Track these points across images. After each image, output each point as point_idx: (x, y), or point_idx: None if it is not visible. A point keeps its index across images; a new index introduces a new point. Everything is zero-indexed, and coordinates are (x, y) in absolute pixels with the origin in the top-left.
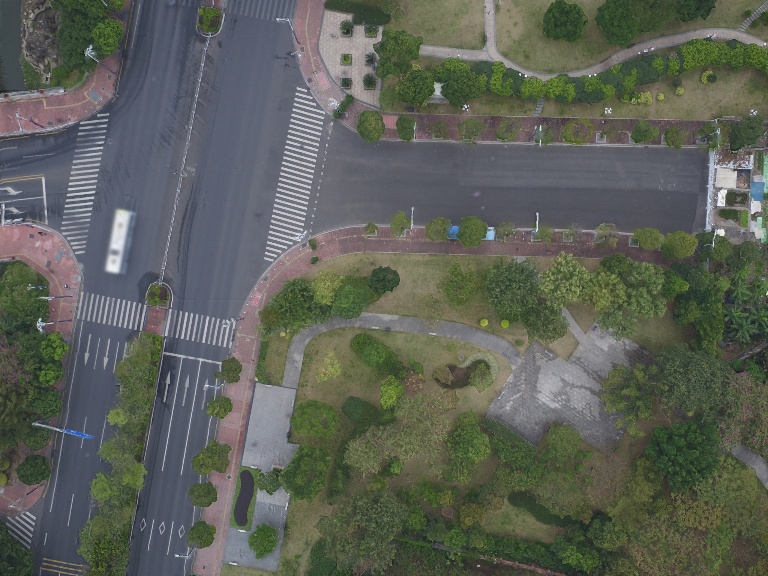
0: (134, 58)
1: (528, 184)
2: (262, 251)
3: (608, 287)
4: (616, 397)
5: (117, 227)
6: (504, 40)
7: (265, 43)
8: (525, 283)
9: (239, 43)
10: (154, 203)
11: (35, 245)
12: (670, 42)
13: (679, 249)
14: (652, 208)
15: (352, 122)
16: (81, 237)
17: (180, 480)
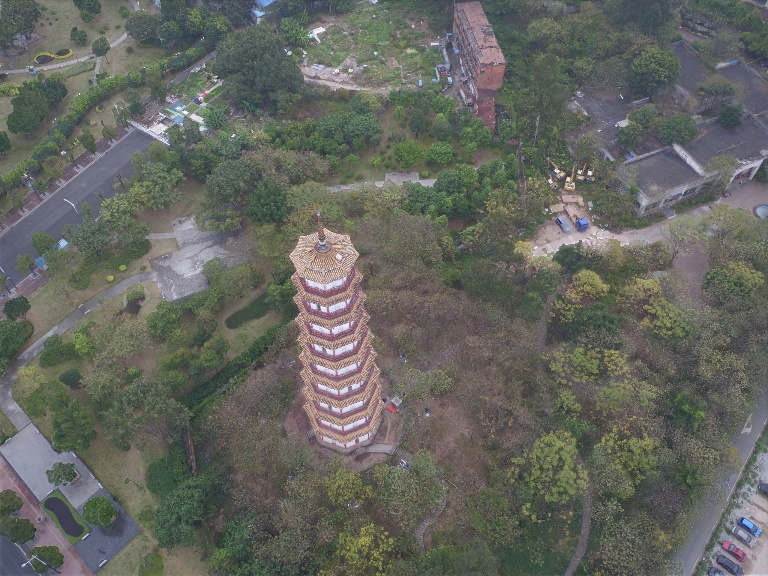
0: None
1: (63, 214)
2: None
3: None
4: None
5: None
6: None
7: None
8: None
9: None
10: None
11: None
12: None
13: (154, 149)
14: None
15: None
16: None
17: (2, 564)
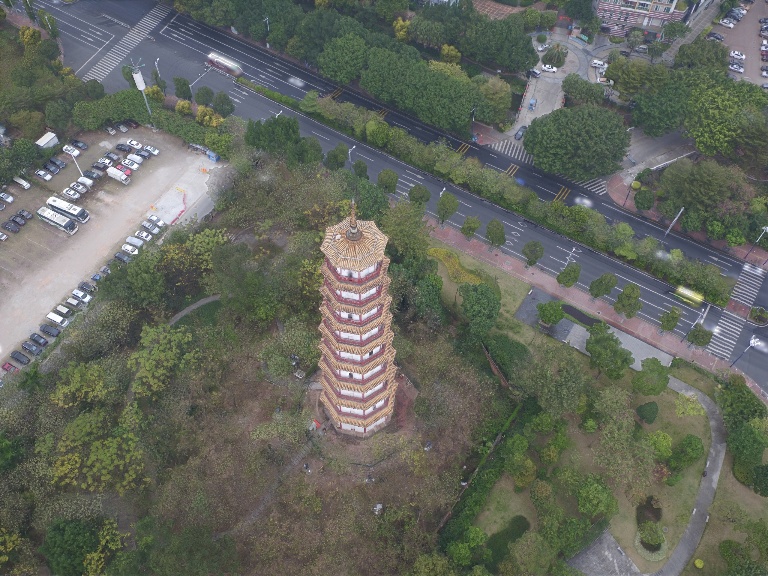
0: None
1: None
2: None
3: None
4: None
5: None
6: None
7: None
8: None
9: None
10: None
11: None
12: None
13: None
14: None
15: None
16: None
17: None
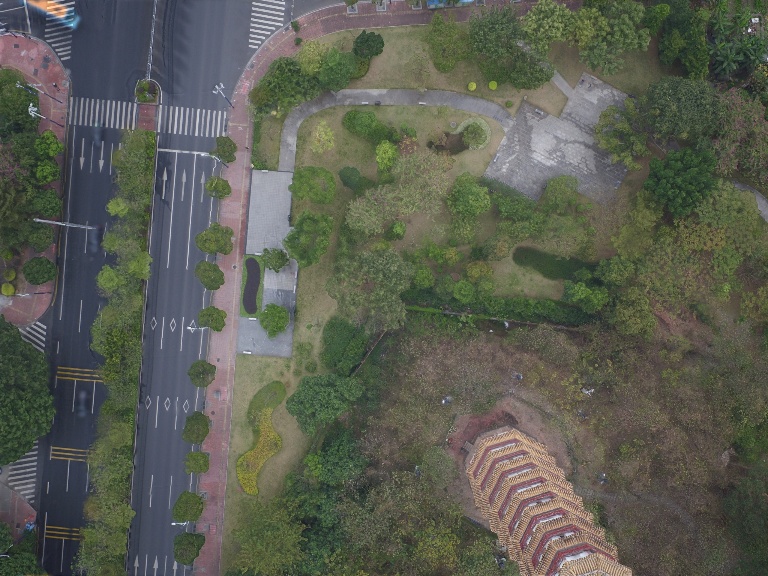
0: None
1: None
2: (246, 39)
3: (590, 21)
4: (610, 138)
5: (100, 29)
6: None
7: None
8: (508, 26)
9: None
10: (134, 1)
11: (20, 54)
12: None
13: None
14: None
15: None
16: (65, 43)
17: (186, 275)
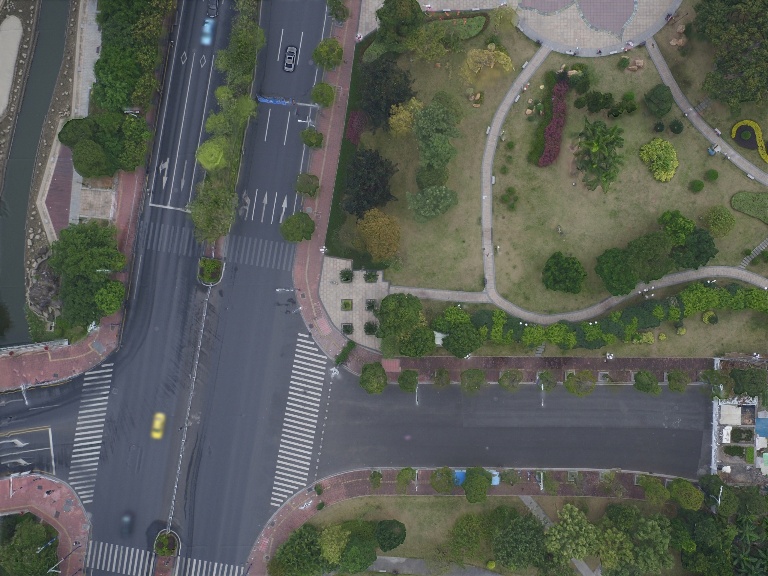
0: (137, 309)
1: (532, 424)
2: (268, 496)
3: (615, 545)
4: None
5: (124, 476)
6: (504, 282)
7: (266, 291)
8: (531, 542)
9: (240, 291)
10: (160, 452)
11: (43, 496)
12: (670, 281)
13: (685, 505)
14: (657, 446)
15: (354, 366)
16: (88, 486)
17: None
